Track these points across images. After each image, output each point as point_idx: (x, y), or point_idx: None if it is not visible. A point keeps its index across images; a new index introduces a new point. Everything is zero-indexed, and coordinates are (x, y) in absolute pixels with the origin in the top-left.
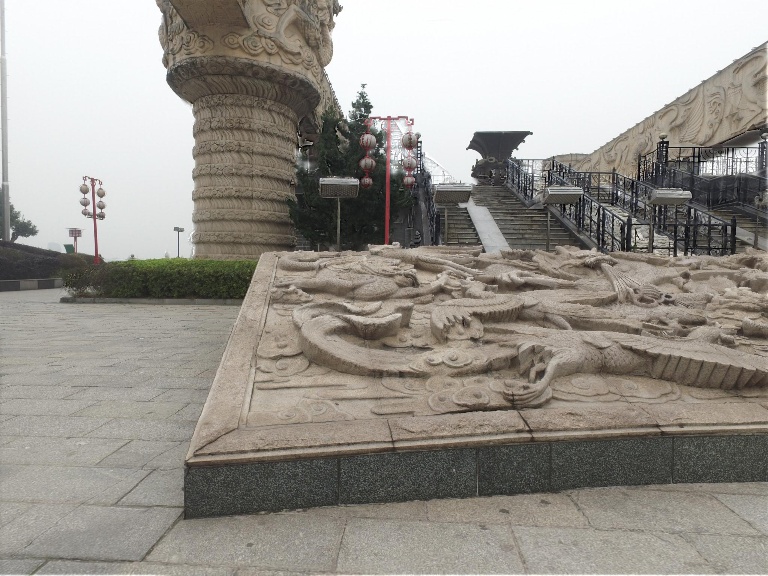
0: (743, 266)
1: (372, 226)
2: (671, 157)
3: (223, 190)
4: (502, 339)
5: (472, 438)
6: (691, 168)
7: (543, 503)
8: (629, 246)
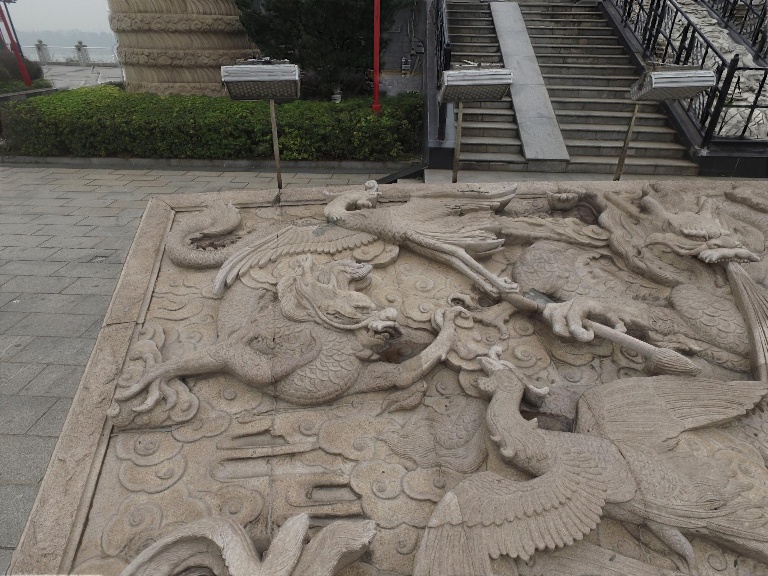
0: None
1: (357, 39)
2: None
3: None
4: None
5: None
6: None
7: None
8: (721, 103)
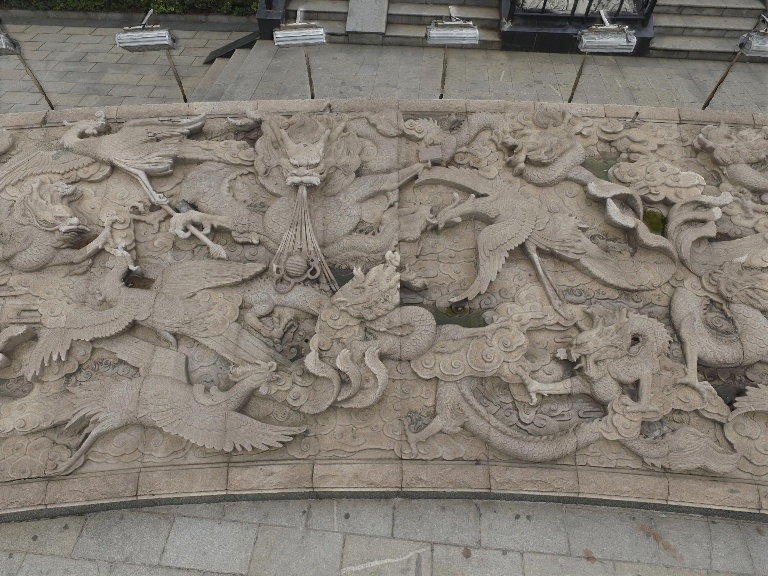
0: (504, 150)
1: None
2: None
3: None
4: (76, 392)
5: (6, 510)
6: None
7: (64, 528)
8: None
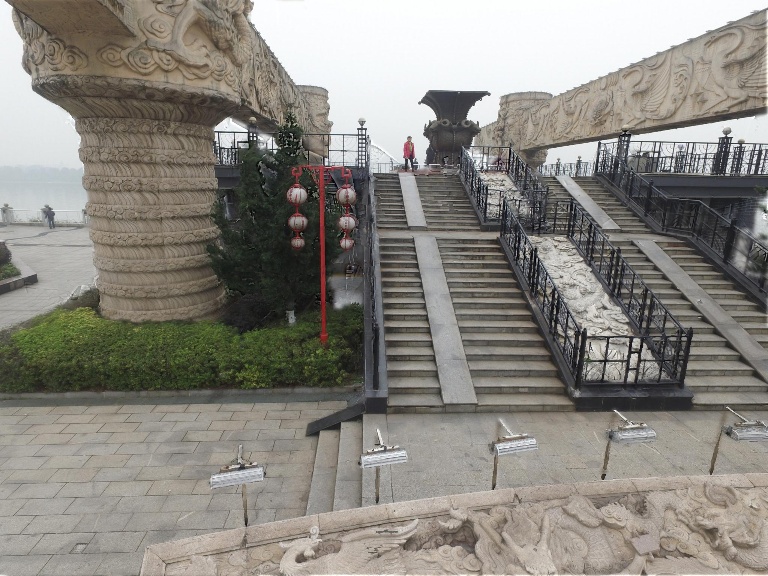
0: (701, 531)
1: (308, 274)
2: (631, 152)
3: (126, 238)
4: None
5: None
6: (650, 164)
7: None
8: (582, 360)
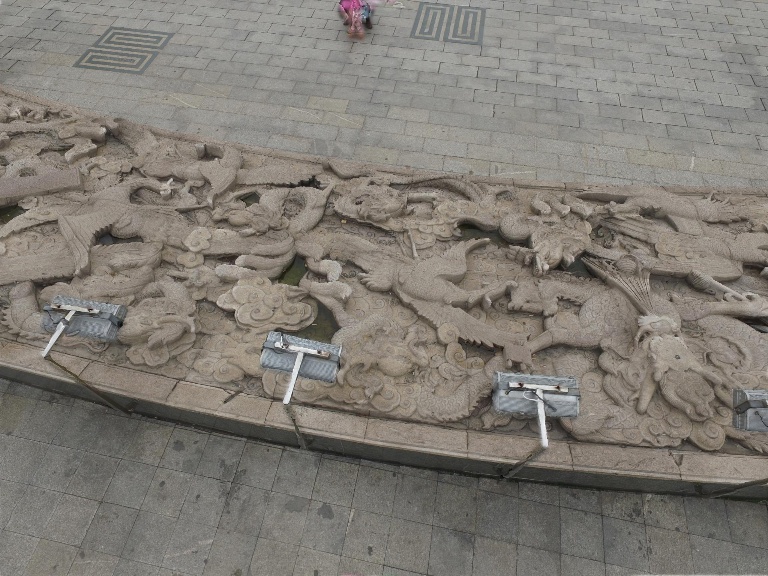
0: None
1: None
2: None
3: None
4: None
5: None
6: None
7: None
8: None
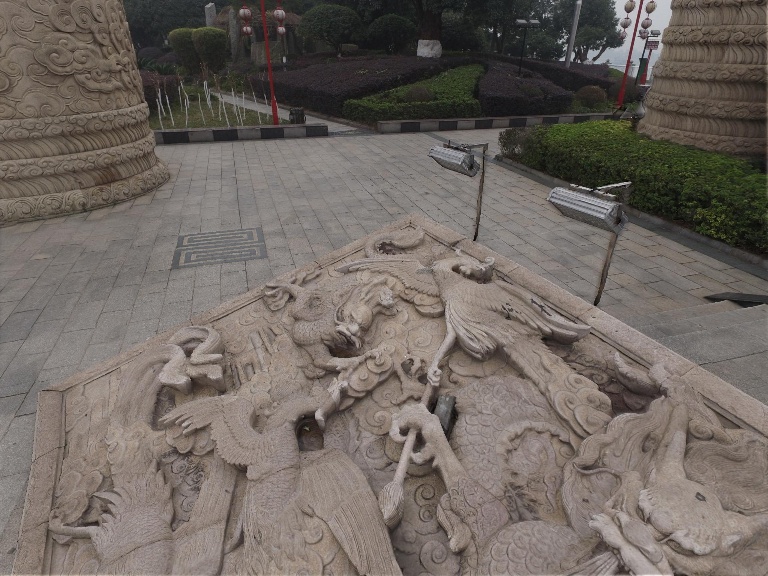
0: None
1: None
2: None
3: (687, 32)
4: (146, 473)
5: None
6: None
7: None
8: None
